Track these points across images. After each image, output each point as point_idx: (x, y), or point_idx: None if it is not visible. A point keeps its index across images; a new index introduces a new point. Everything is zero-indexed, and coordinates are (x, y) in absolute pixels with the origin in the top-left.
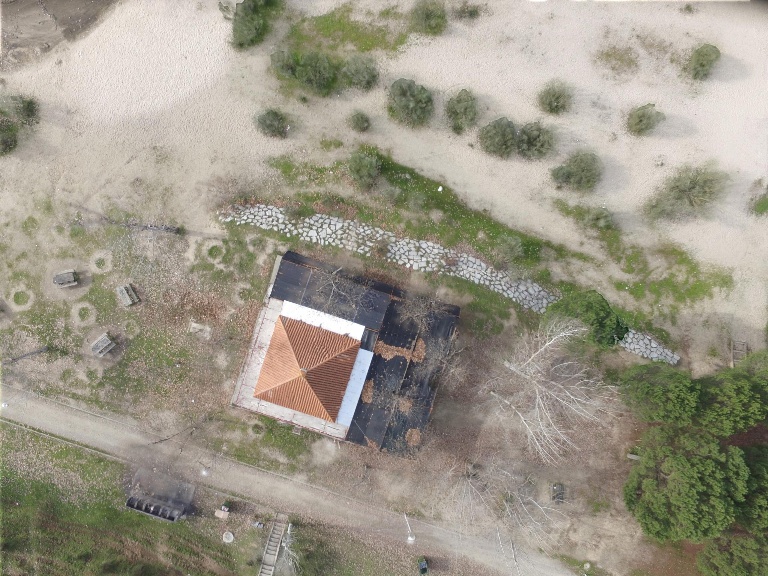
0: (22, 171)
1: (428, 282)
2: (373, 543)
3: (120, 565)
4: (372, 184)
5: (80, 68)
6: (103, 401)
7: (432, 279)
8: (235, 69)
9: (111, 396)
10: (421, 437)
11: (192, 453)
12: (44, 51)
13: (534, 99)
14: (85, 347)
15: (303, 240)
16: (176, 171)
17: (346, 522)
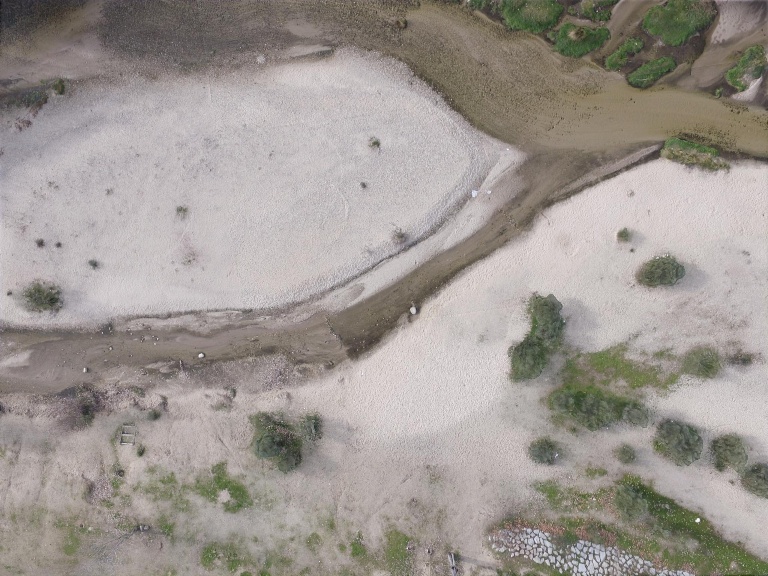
0: (306, 487)
1: None
2: None
3: None
4: None
5: (362, 388)
6: None
7: None
8: (510, 398)
9: None
10: None
11: None
12: (328, 368)
13: None
14: None
15: None
16: (449, 492)
17: None
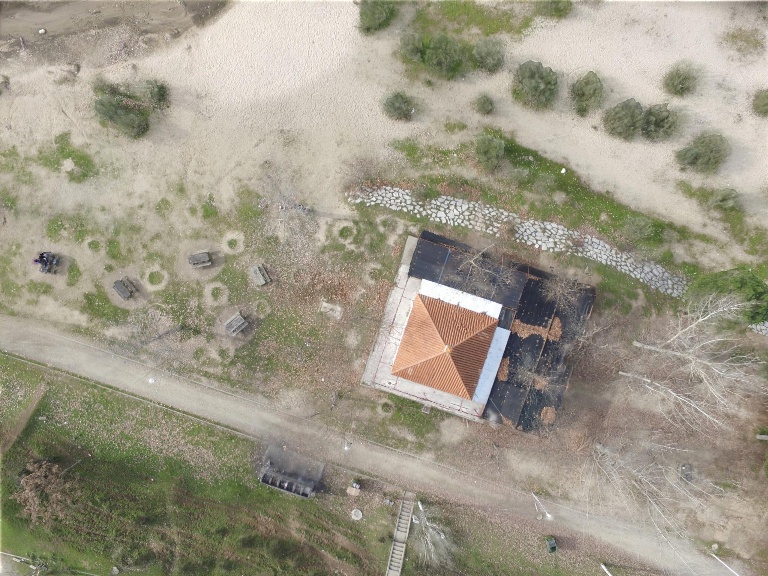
0: (155, 154)
1: (557, 262)
2: (500, 522)
3: (256, 540)
4: (496, 166)
5: (209, 53)
6: (234, 379)
7: (561, 259)
8: (361, 53)
9: (242, 374)
10: (556, 415)
11: (321, 431)
12: (174, 37)
13: (658, 81)
14: (217, 326)
15: (433, 221)
16: (303, 154)
17: (473, 501)
